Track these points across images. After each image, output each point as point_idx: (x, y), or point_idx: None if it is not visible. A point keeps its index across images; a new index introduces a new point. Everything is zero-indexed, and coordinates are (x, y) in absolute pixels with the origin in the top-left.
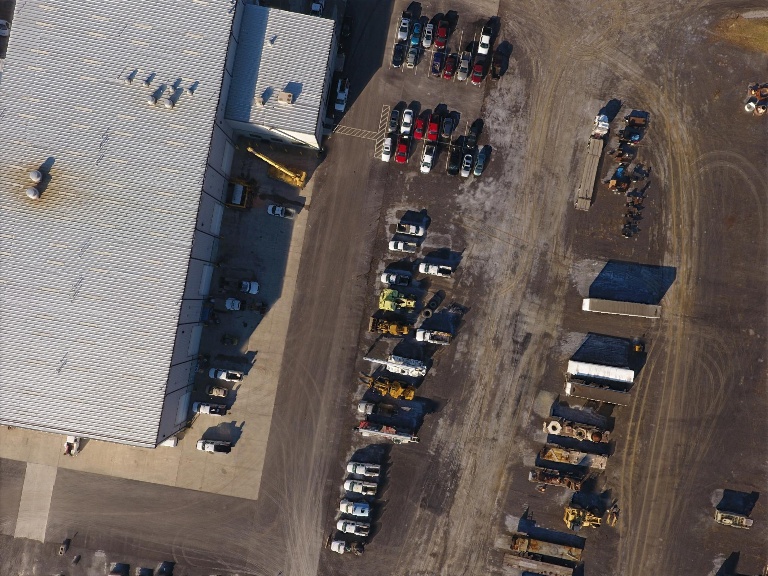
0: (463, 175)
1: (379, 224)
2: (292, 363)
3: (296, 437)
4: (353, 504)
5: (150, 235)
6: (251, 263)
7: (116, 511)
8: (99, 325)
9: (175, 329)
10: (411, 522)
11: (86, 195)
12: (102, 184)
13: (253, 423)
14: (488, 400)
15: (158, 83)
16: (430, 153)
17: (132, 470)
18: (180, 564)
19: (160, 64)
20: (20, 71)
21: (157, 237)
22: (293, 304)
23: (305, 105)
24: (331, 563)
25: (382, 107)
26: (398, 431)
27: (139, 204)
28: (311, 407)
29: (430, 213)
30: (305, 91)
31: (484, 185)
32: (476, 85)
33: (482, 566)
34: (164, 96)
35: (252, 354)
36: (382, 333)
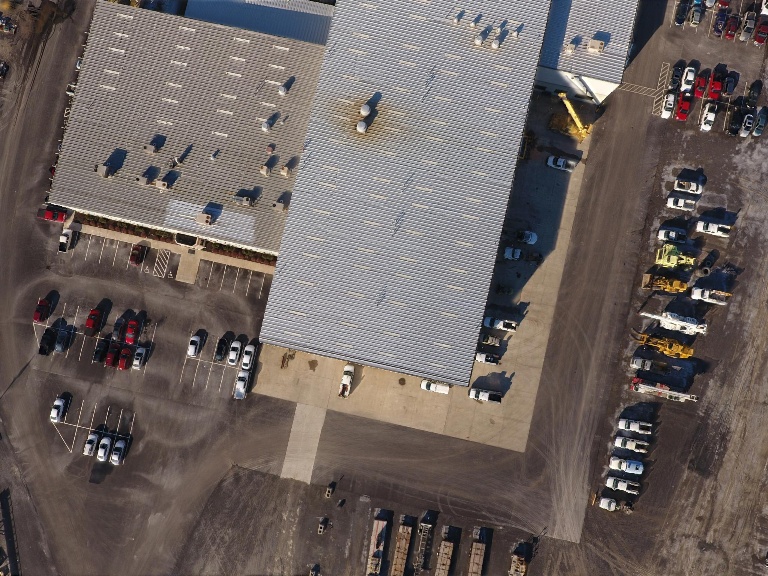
0: (742, 135)
1: (655, 181)
2: (564, 316)
3: (566, 391)
4: (626, 461)
5: (471, 173)
6: (526, 214)
7: (383, 456)
8: (418, 260)
9: (492, 268)
10: (678, 483)
11: (411, 131)
12: (427, 121)
13: (523, 374)
14: (760, 363)
15: (484, 24)
16: (711, 111)
17: (401, 416)
18: (445, 513)
19: (487, 5)
20: (352, 7)
21: (478, 176)
22: (567, 257)
23: (613, 54)
24: (596, 521)
25: (662, 64)
26: (672, 389)
27: (462, 142)
28: (582, 361)
29: (706, 172)
30: (613, 40)
31: (761, 146)
32: (757, 46)
33: (749, 533)
34: (490, 37)
35: (524, 305)
36: (656, 290)
